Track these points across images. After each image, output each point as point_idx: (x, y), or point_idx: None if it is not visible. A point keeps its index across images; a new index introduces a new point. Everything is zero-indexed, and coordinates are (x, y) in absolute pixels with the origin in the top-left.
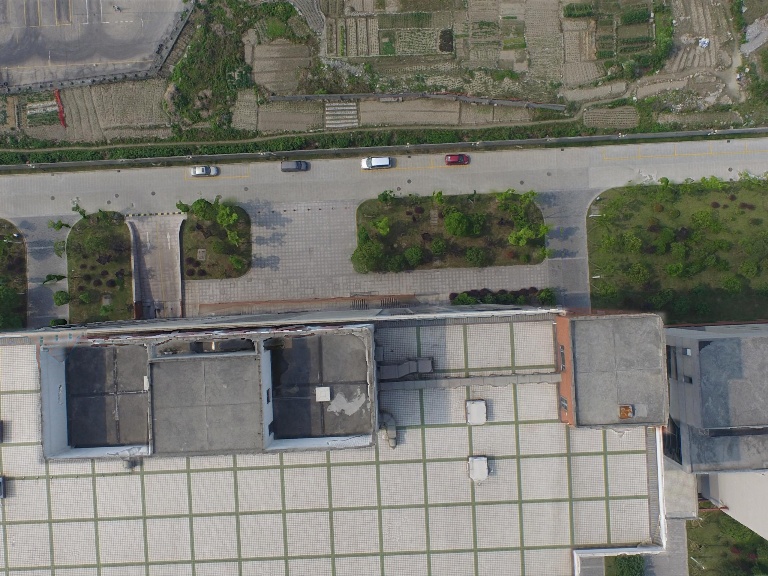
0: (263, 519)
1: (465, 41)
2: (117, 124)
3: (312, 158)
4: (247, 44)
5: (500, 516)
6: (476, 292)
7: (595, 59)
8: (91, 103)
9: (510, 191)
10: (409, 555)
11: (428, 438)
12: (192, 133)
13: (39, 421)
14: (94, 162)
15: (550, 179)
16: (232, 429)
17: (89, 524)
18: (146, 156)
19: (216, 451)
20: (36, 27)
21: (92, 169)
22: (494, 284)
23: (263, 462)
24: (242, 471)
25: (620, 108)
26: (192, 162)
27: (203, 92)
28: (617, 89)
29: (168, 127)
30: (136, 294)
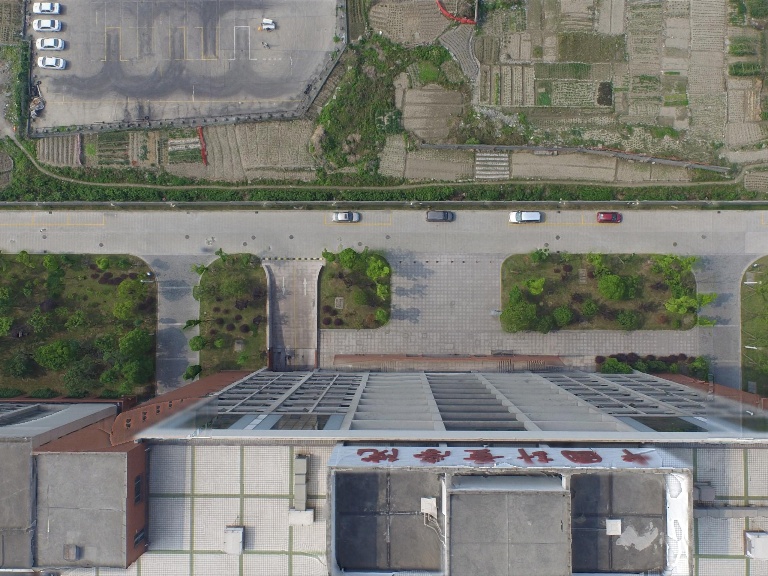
0: None
1: (624, 95)
2: (260, 165)
3: (458, 208)
4: (398, 88)
5: None
6: (624, 356)
7: (759, 120)
8: (235, 142)
9: (662, 252)
10: None
11: (702, 569)
12: (336, 177)
13: (285, 529)
14: (234, 203)
15: (705, 242)
16: (536, 570)
17: None
18: (288, 199)
19: None
20: (181, 60)
21: (229, 209)
22: (641, 348)
23: None
24: None
25: None
26: (333, 207)
27: (352, 136)
28: None
29: (312, 170)
30: (270, 341)
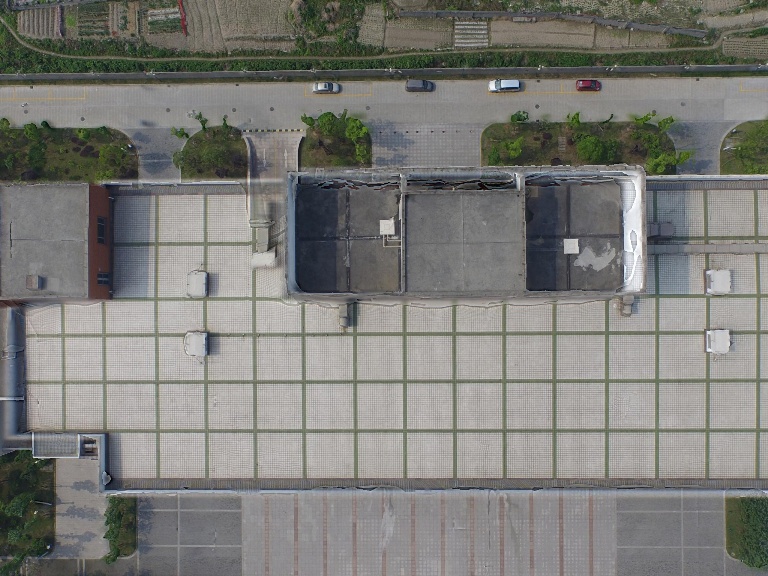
0: (482, 388)
1: None
2: (240, 34)
3: (438, 78)
4: None
5: (736, 395)
6: None
7: None
8: (214, 12)
9: None
10: (636, 433)
11: (662, 309)
12: (316, 47)
13: (248, 275)
14: (214, 73)
15: (684, 109)
16: (491, 269)
17: (296, 386)
18: (268, 69)
19: (473, 292)
20: None
21: (210, 82)
22: None
23: (484, 327)
24: (462, 336)
25: (761, 38)
26: (313, 78)
27: (331, 4)
28: (759, 17)
29: (292, 40)
30: (251, 211)
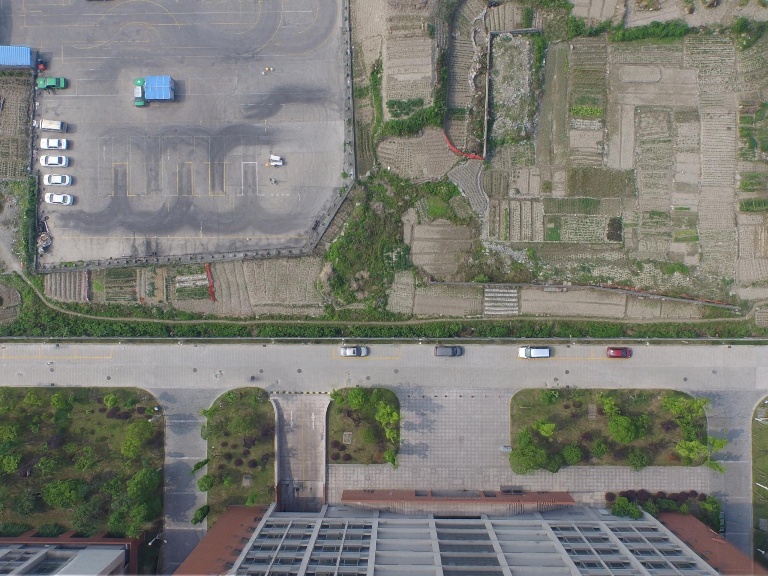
0: None
1: (634, 230)
2: (268, 301)
3: (467, 343)
4: (406, 224)
5: None
6: (634, 494)
7: None
8: (242, 278)
9: (673, 388)
10: None
11: None
12: (345, 313)
13: None
14: None
15: (715, 377)
16: None
17: None
18: (296, 334)
19: None
20: (188, 196)
21: (237, 342)
22: (652, 484)
23: None
24: None
25: None
26: (341, 341)
27: (360, 274)
28: None
29: (321, 306)
30: (278, 476)
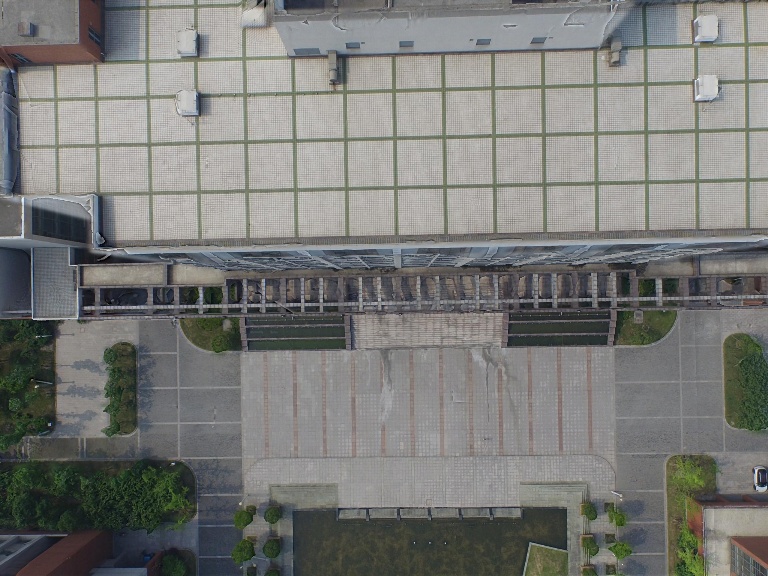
0: (471, 143)
1: None
2: None
3: None
4: None
5: (725, 145)
6: None
7: None
8: None
9: None
10: (626, 185)
11: (651, 60)
12: None
13: (238, 35)
14: None
15: None
16: None
17: (287, 145)
18: None
19: (459, 5)
20: None
21: None
22: None
23: (473, 83)
24: (451, 92)
25: None
26: None
27: None
28: None
29: None
30: None
